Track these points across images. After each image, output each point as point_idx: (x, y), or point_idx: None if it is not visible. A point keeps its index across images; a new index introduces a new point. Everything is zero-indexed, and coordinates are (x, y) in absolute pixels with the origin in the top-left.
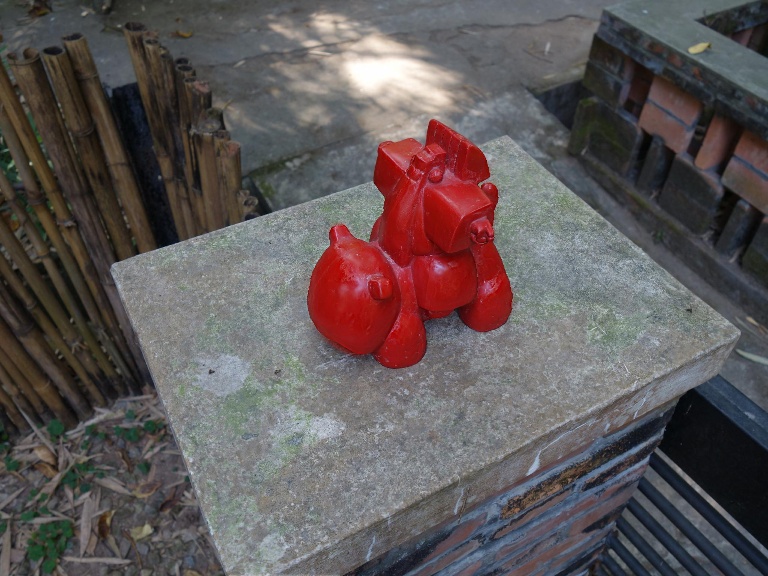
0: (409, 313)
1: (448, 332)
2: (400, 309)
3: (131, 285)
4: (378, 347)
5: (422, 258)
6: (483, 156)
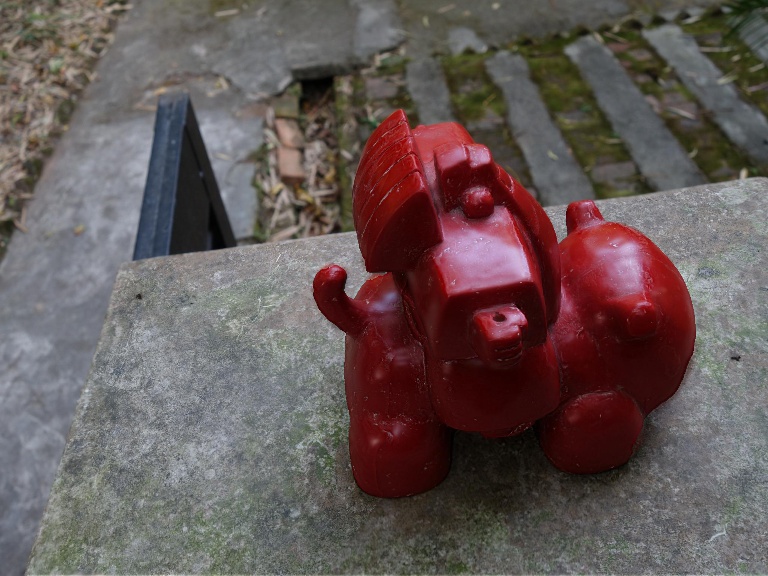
0: None
1: None
2: None
3: None
4: None
5: None
6: None
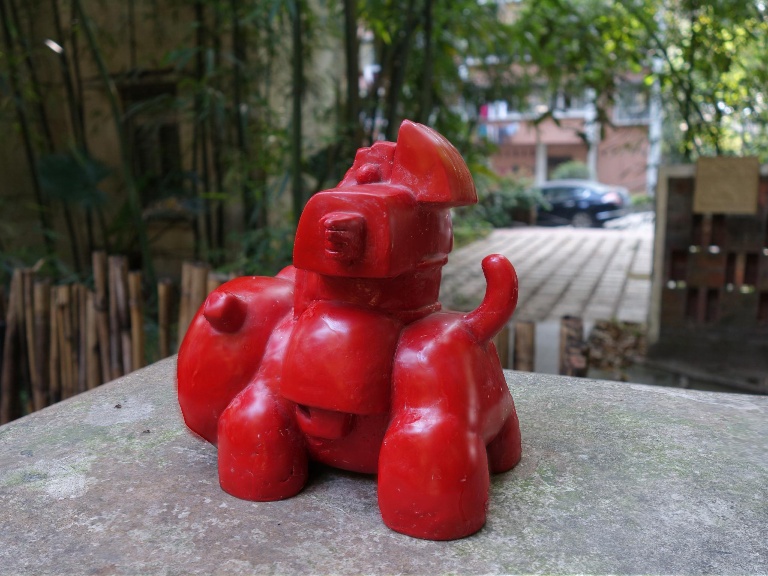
0: (264, 391)
1: (349, 502)
2: (255, 376)
3: None
4: (211, 429)
5: (310, 304)
6: (433, 150)
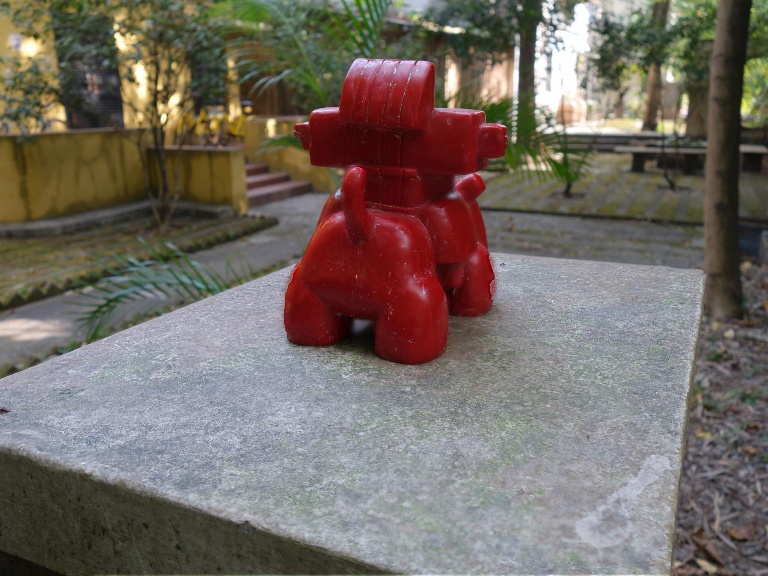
0: None
1: None
2: None
3: (657, 269)
4: None
5: None
6: None
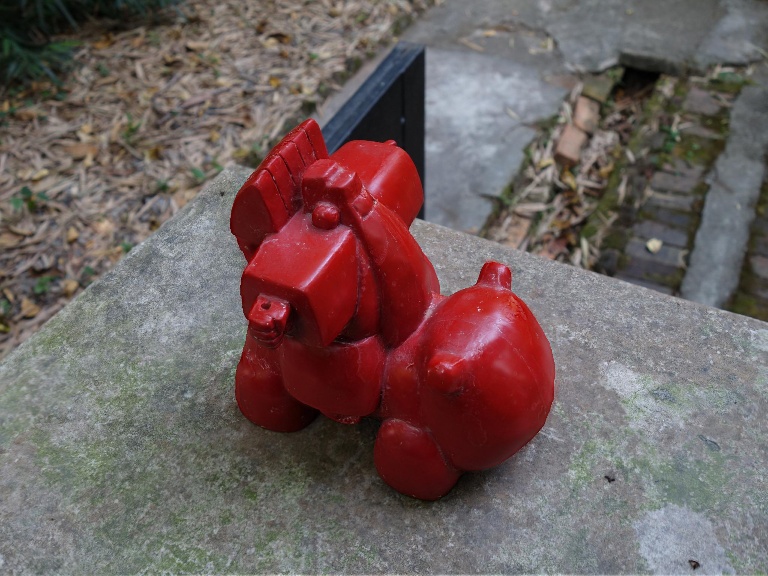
0: None
1: None
2: None
3: None
4: None
5: None
6: None
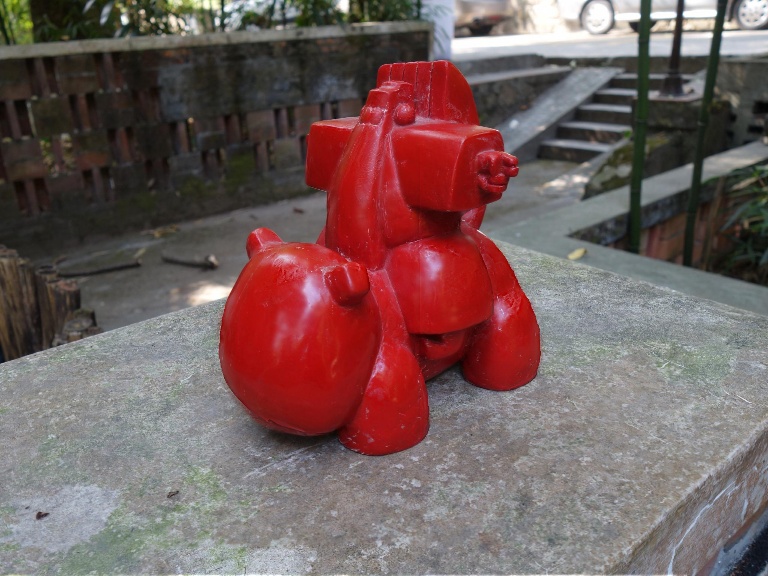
0: (396, 344)
1: (455, 399)
2: (381, 336)
3: None
4: (353, 410)
5: (403, 247)
6: (467, 86)
